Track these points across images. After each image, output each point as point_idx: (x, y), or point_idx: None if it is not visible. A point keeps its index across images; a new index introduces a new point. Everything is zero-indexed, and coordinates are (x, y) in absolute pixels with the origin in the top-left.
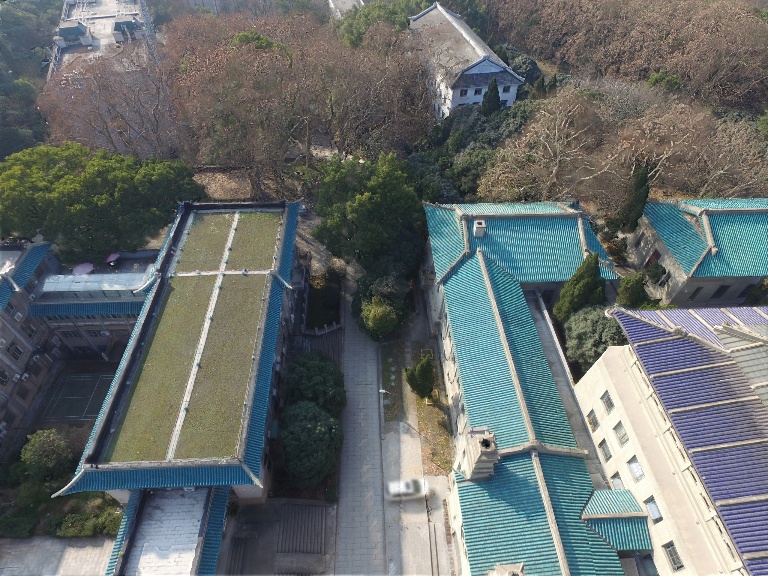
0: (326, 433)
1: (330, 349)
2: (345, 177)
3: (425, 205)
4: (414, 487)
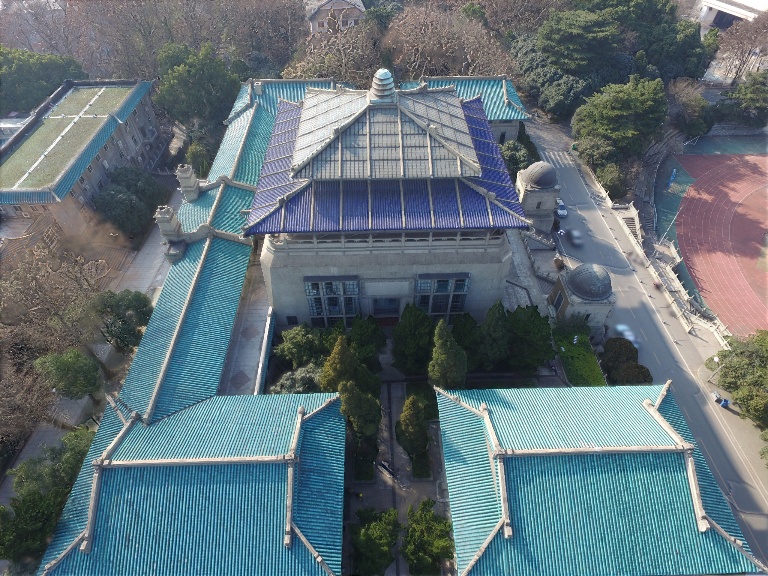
0: (127, 201)
1: (169, 184)
2: (172, 57)
3: (242, 84)
4: None
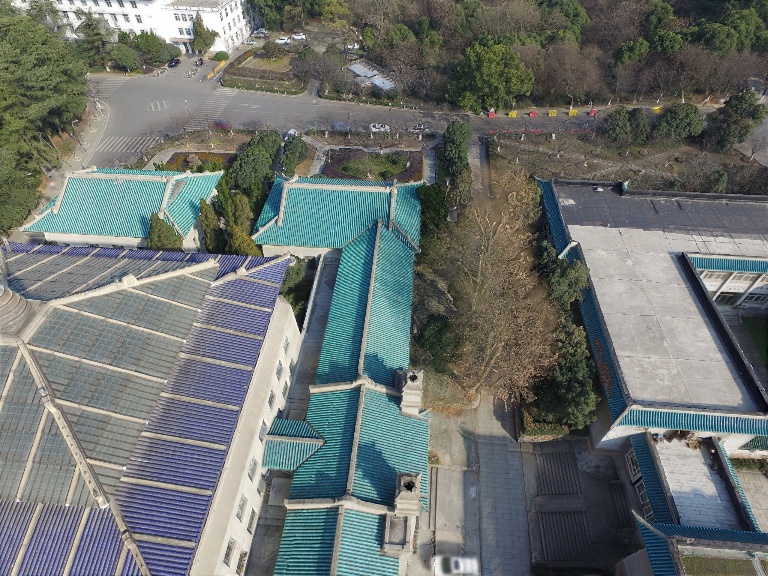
0: None
1: None
2: None
3: None
4: (447, 572)
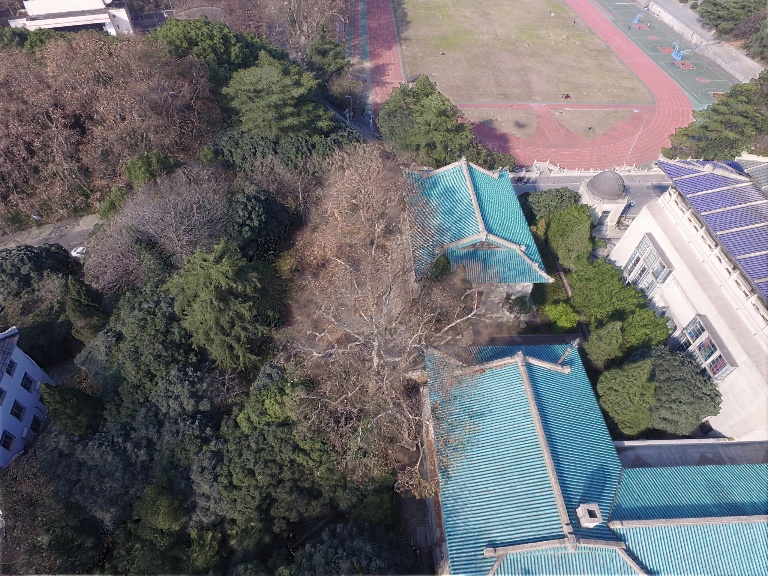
0: None
1: None
2: None
3: None
4: None
